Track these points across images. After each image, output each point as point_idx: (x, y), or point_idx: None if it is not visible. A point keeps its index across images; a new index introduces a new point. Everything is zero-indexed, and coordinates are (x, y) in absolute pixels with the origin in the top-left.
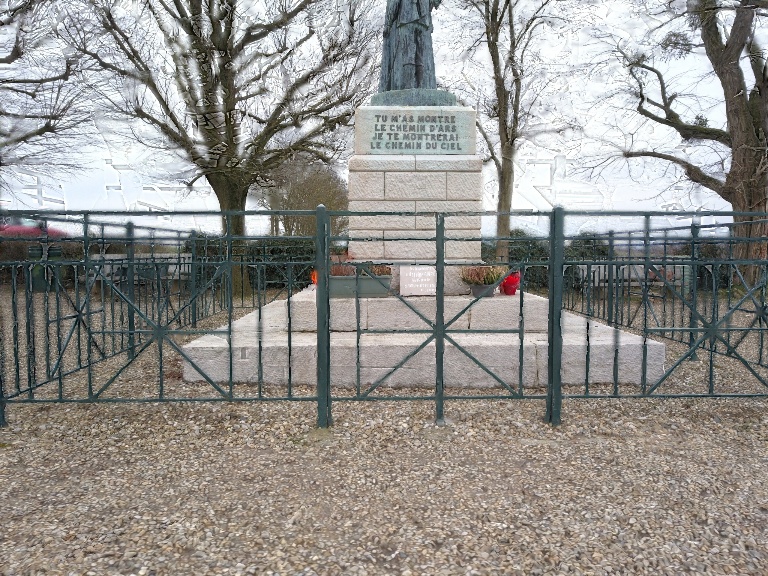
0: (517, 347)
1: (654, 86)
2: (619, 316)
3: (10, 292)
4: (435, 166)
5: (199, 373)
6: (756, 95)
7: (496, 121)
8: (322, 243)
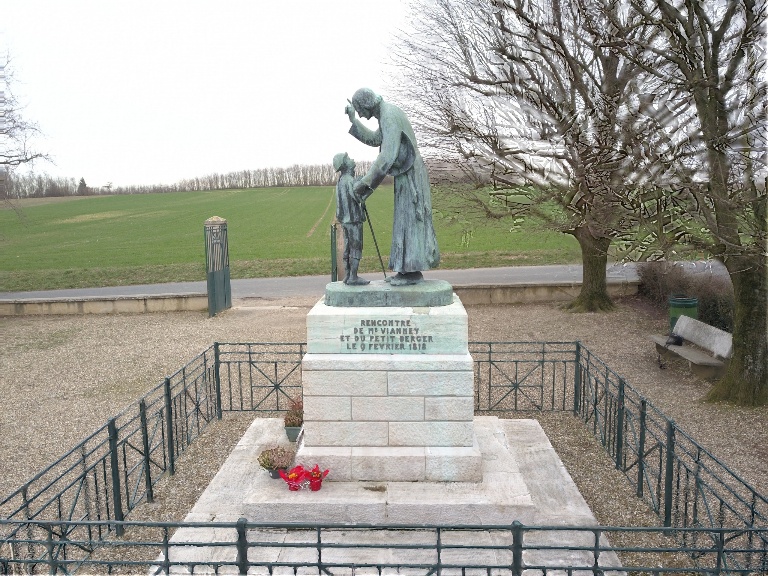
0: None
1: None
2: None
3: (656, 332)
4: None
5: None
6: None
7: None
8: None
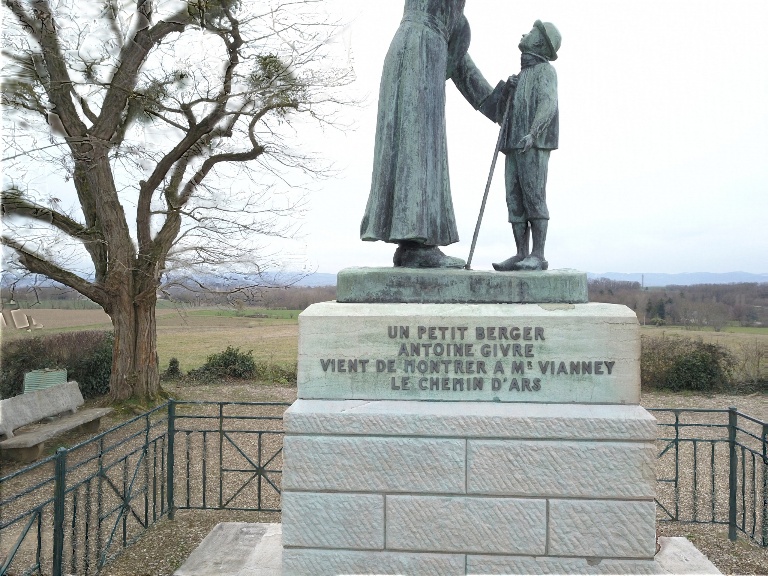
0: None
1: None
2: (195, 489)
3: None
4: None
5: None
6: (135, 192)
7: None
8: None
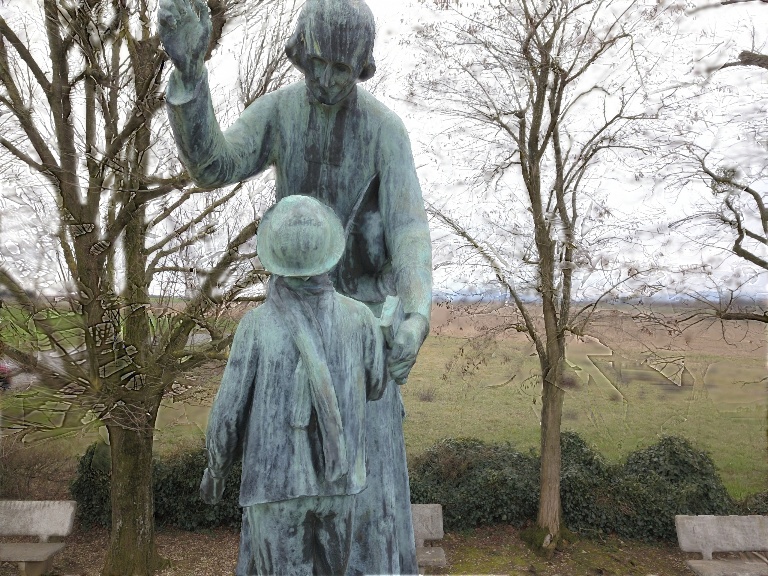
0: None
1: (750, 212)
2: None
3: None
4: None
5: None
6: None
7: (533, 266)
8: None
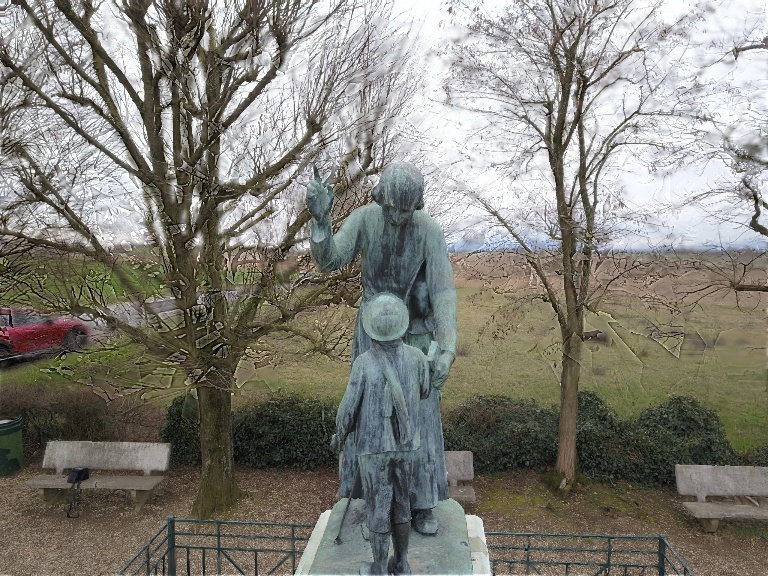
0: None
1: None
2: None
3: None
4: None
5: None
6: None
7: (560, 241)
8: None
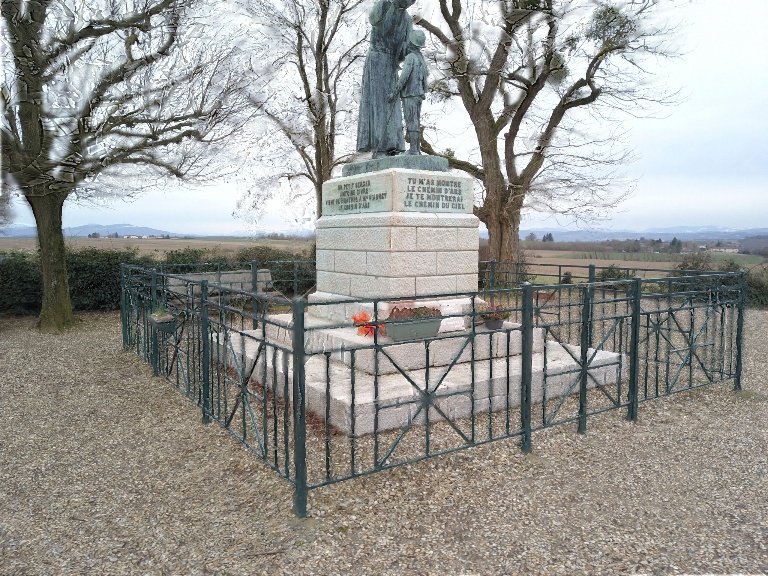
0: (560, 368)
1: None
2: None
3: None
4: (451, 223)
5: (453, 428)
6: None
7: None
8: (531, 313)
